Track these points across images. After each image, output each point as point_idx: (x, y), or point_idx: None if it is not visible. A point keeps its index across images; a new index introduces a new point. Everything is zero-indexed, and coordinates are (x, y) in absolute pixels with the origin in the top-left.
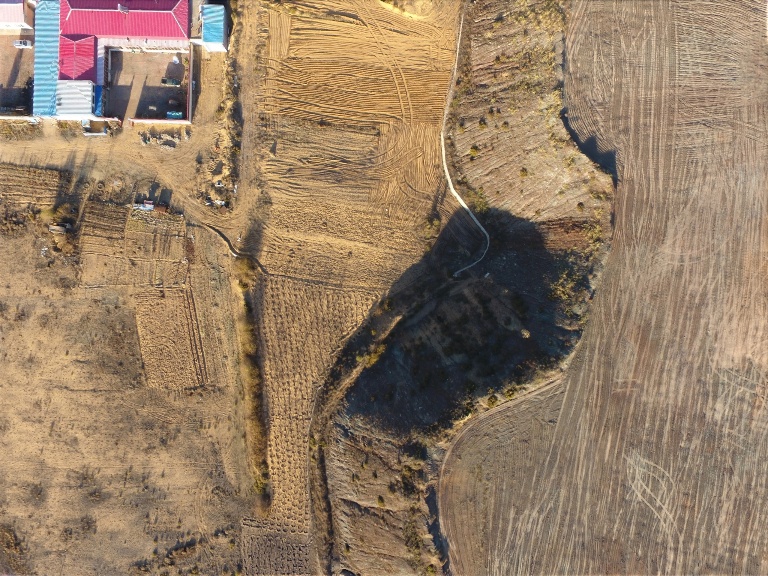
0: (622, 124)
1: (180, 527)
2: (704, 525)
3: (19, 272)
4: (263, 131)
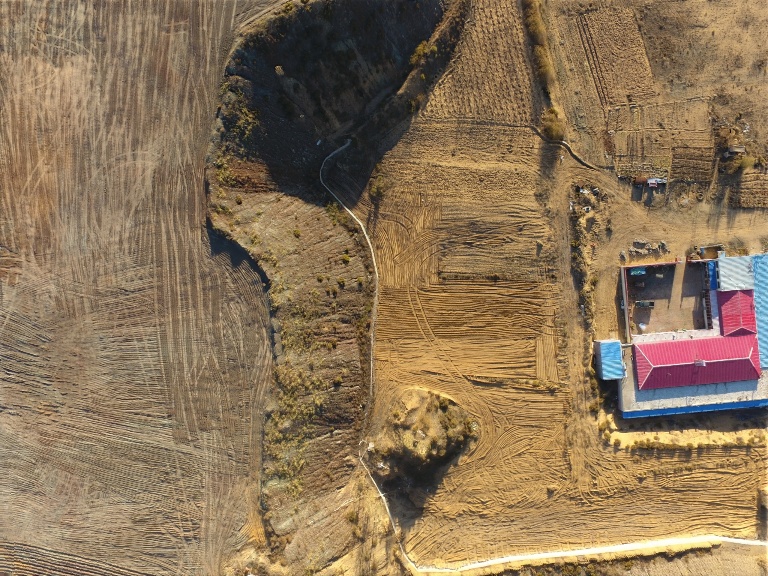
0: (208, 282)
1: None
2: None
3: (767, 106)
4: (551, 265)
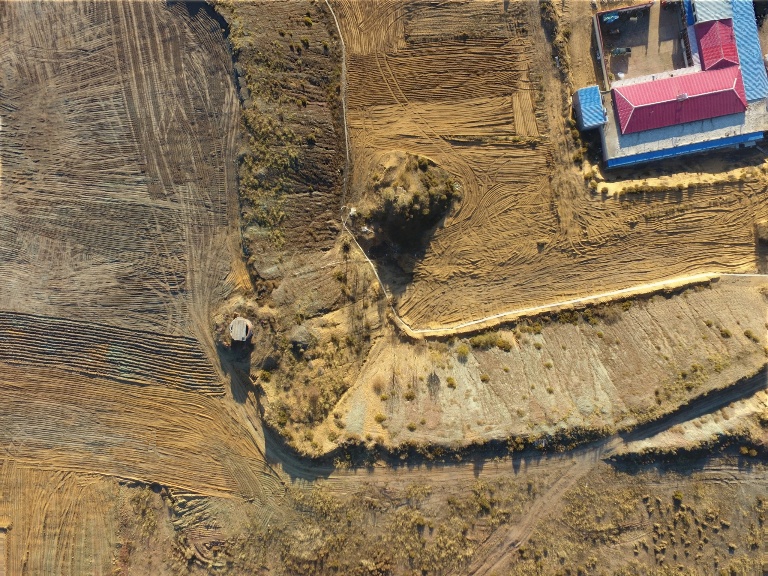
0: (167, 33)
1: None
2: None
3: None
4: (520, 19)
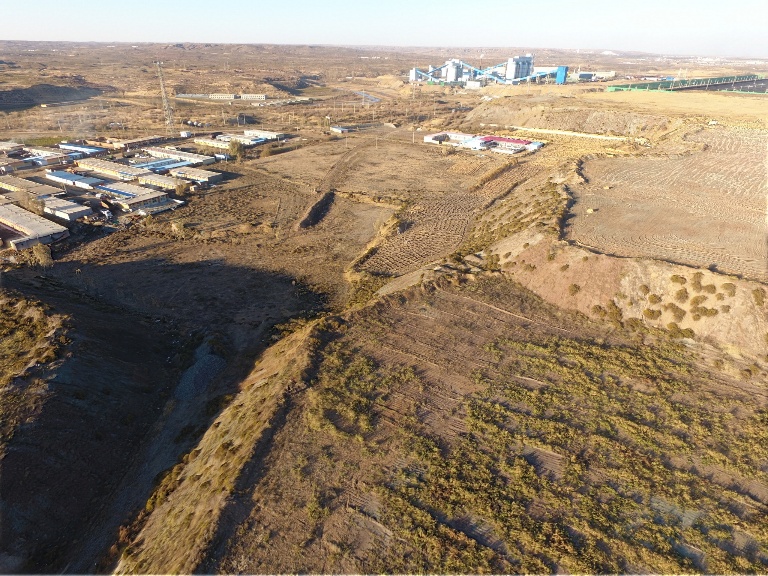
0: None
1: (423, 188)
2: (766, 190)
3: None
4: None
